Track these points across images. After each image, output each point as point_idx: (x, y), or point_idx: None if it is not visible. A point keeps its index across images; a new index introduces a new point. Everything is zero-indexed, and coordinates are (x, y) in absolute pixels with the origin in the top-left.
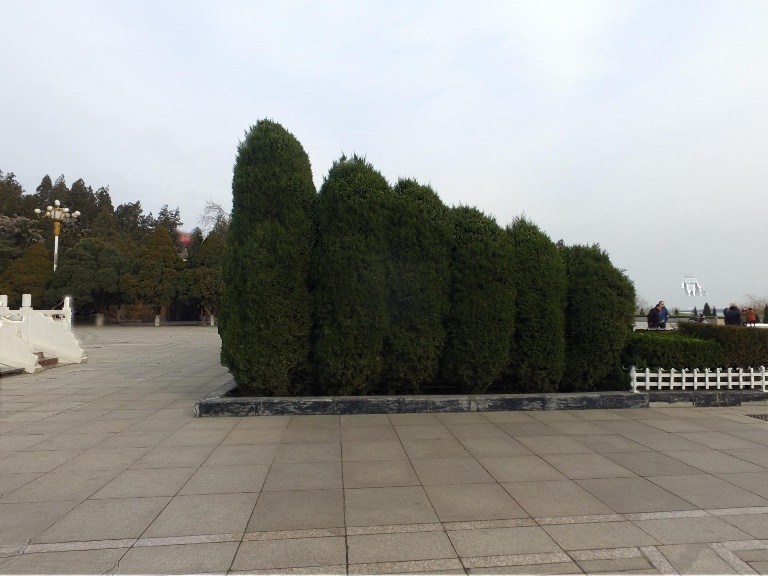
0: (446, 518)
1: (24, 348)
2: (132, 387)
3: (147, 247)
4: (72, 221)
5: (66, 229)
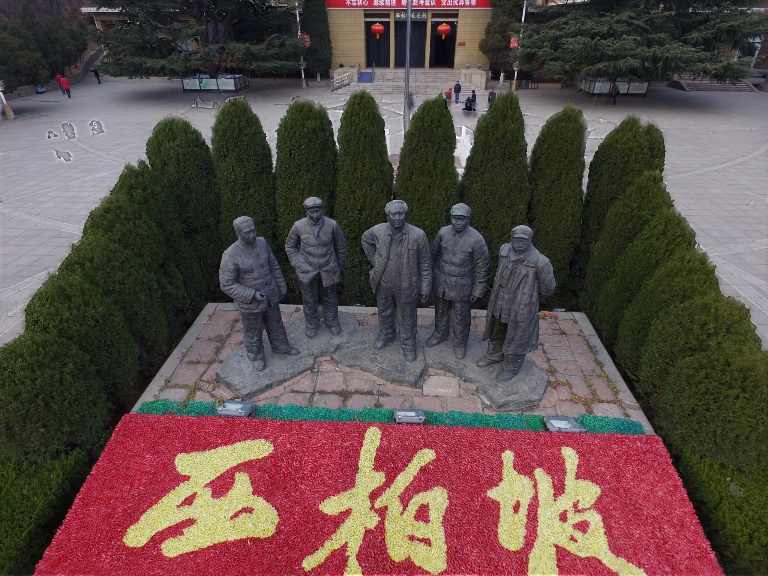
0: (6, 334)
1: None
2: None
3: None
4: None
5: None
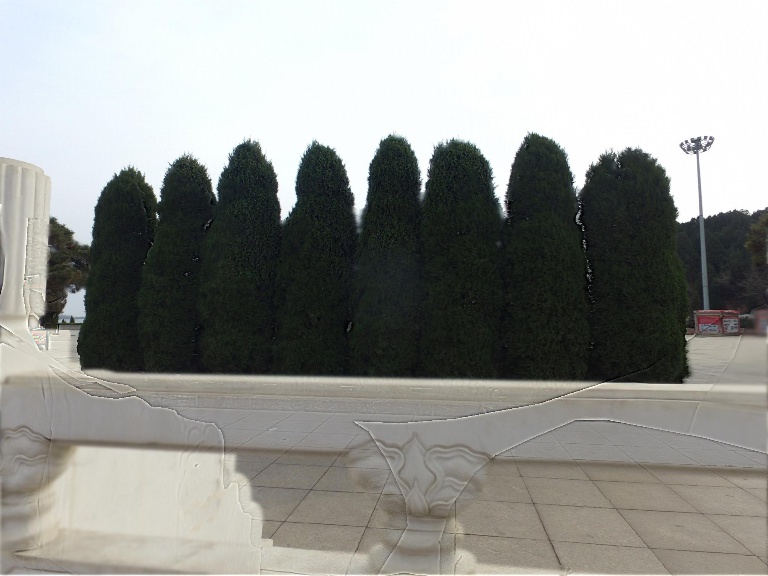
0: None
1: (241, 531)
2: (574, 457)
3: None
4: None
5: None
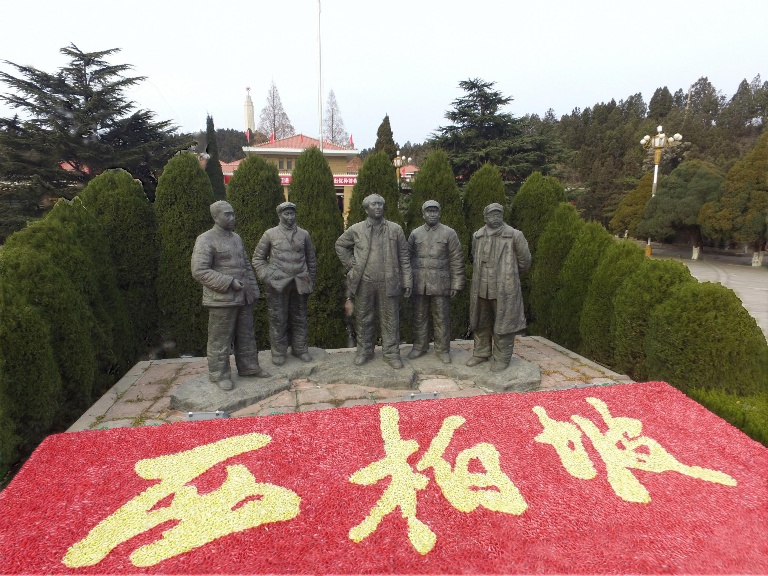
0: None
1: None
2: None
3: (741, 165)
4: (674, 145)
5: (667, 155)
